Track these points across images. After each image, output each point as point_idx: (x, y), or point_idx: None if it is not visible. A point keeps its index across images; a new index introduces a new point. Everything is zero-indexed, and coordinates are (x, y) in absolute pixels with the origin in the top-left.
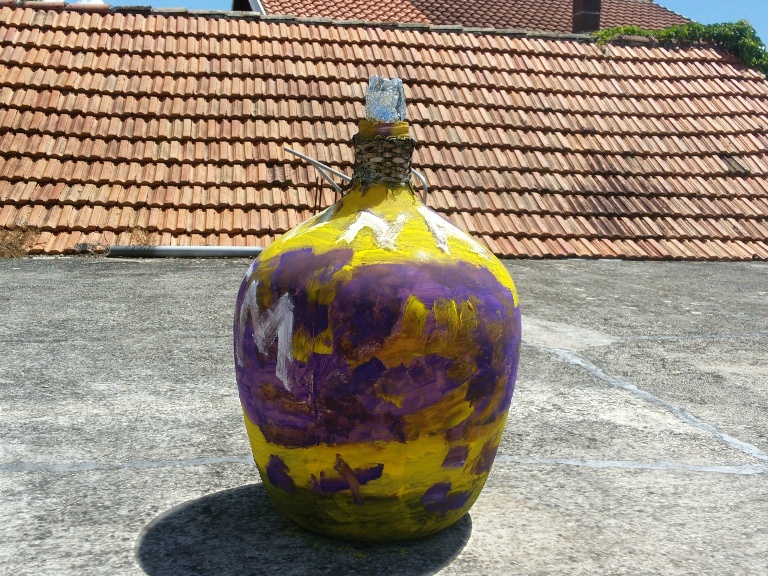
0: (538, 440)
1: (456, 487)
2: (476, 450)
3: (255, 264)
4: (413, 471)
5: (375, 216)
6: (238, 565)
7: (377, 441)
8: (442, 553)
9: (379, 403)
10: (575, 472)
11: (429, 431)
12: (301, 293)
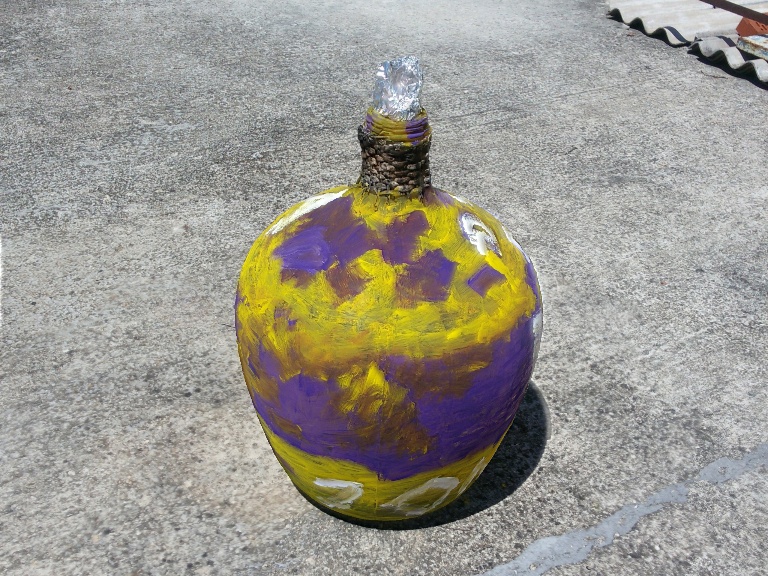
0: None
1: None
2: None
3: None
4: None
5: None
6: None
7: None
8: None
9: None
10: None
11: None
12: None
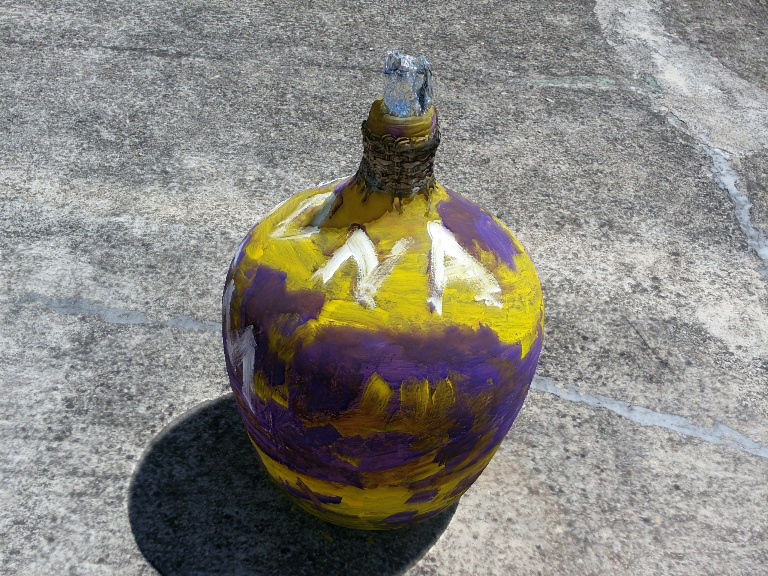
0: (601, 353)
1: (424, 511)
2: (449, 487)
3: (242, 249)
4: (373, 506)
5: (369, 238)
6: (211, 527)
7: (334, 482)
8: (406, 552)
9: (334, 459)
10: (611, 429)
11: (389, 484)
12: (264, 334)
